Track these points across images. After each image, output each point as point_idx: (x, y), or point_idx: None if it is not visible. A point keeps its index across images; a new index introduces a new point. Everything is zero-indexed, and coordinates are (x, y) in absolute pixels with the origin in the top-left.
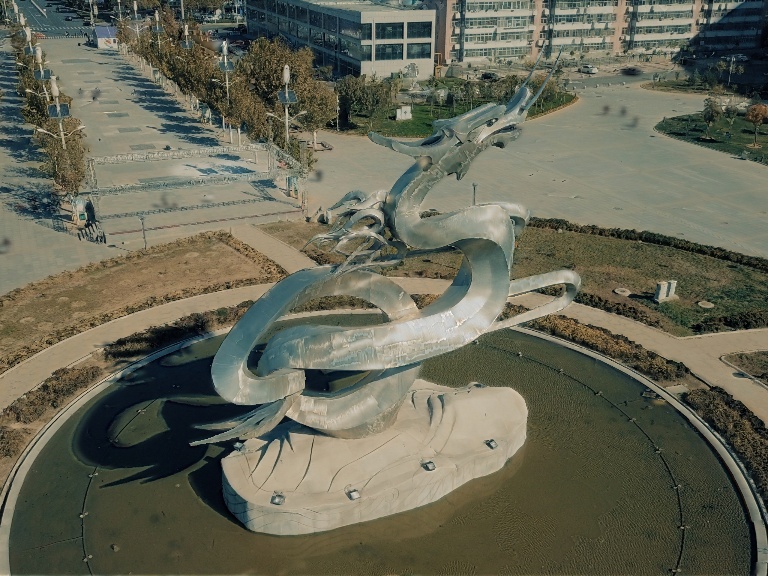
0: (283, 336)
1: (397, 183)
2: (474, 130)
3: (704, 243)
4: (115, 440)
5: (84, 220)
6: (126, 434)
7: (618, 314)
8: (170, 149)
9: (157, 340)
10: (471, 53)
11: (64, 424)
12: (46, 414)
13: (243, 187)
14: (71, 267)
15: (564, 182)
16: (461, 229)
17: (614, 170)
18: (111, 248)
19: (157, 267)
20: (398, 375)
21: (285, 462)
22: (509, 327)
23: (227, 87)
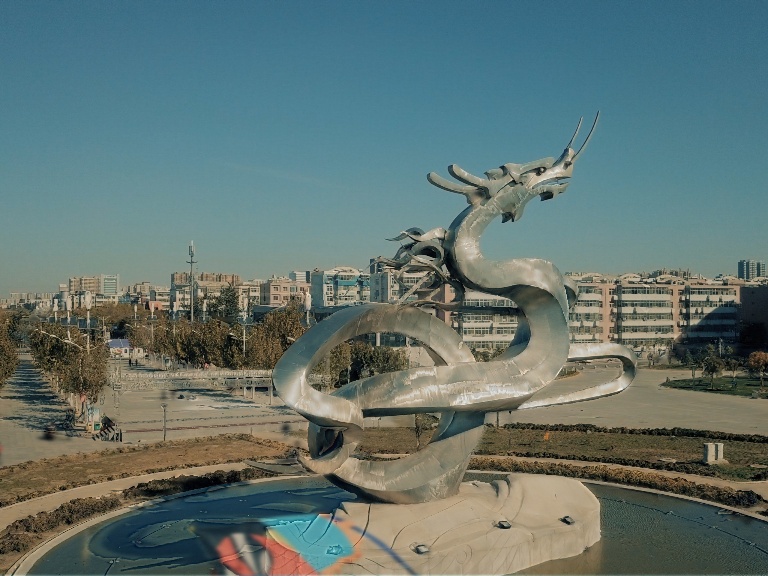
0: (337, 391)
1: (455, 219)
2: (525, 175)
3: (739, 433)
4: (138, 542)
5: (98, 430)
6: (150, 539)
7: (669, 470)
8: (184, 398)
9: (181, 484)
10: (470, 345)
11: (80, 533)
12: (59, 528)
13: (261, 409)
14: (86, 452)
15: (582, 411)
16: (518, 274)
17: (629, 405)
18: (127, 444)
19: (176, 452)
20: (460, 435)
21: (340, 523)
22: (570, 402)
23: (244, 341)
